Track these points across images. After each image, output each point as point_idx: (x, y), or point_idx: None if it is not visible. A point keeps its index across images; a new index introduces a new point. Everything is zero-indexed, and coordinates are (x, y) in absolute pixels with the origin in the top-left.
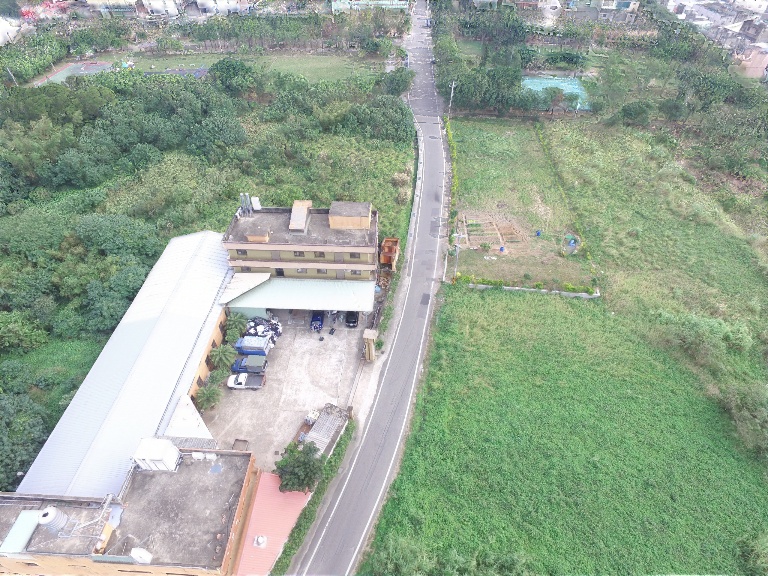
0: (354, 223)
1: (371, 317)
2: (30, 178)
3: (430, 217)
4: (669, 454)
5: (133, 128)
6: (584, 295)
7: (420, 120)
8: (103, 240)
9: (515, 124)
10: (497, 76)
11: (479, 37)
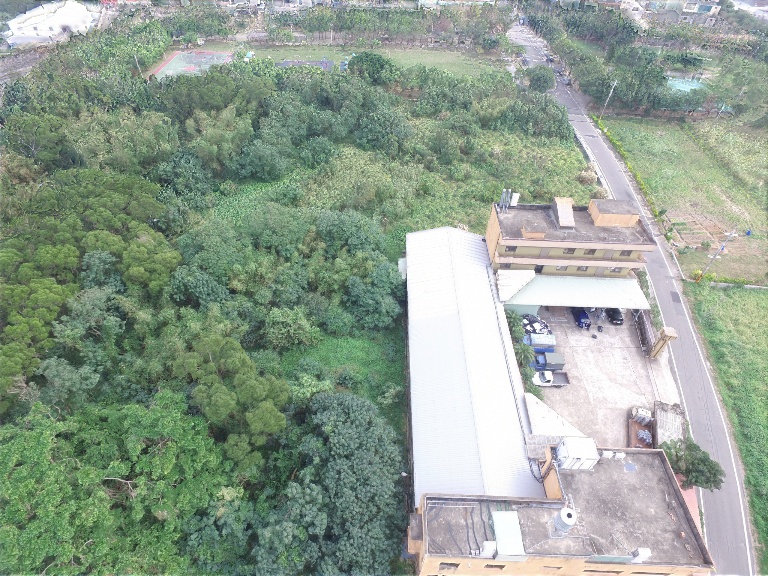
0: (622, 221)
1: (630, 315)
2: (215, 170)
3: None
4: None
5: (302, 120)
6: None
7: (569, 118)
8: (347, 235)
9: (660, 124)
10: (645, 76)
11: (578, 36)
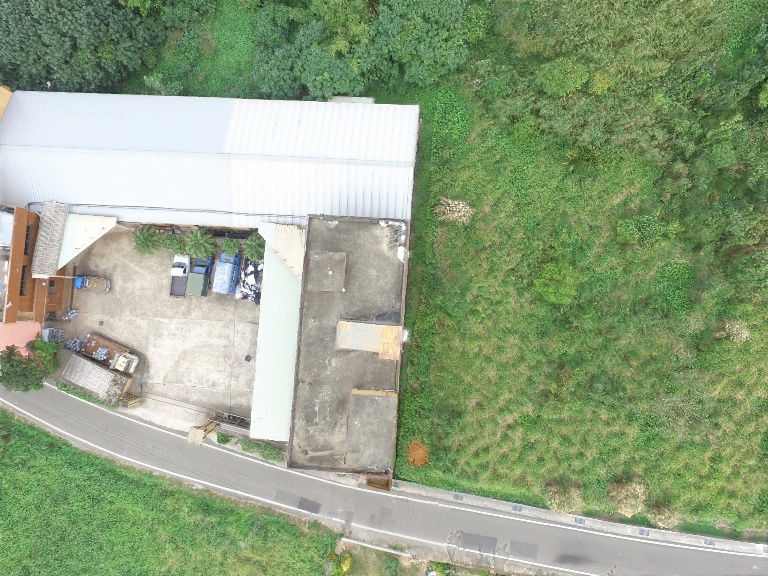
0: None
1: None
2: None
3: (508, 538)
4: None
5: None
6: None
7: None
8: None
9: None
10: None
11: None
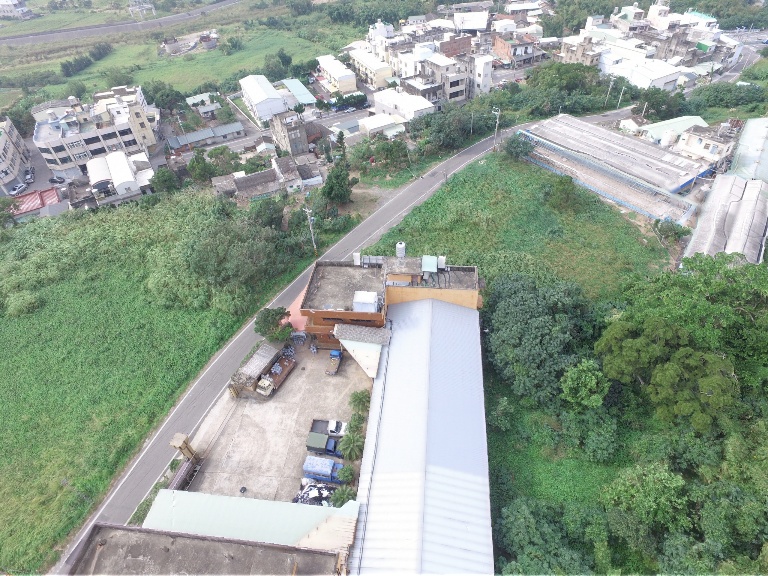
0: None
1: None
2: None
3: None
4: (8, 360)
5: None
6: None
7: None
8: None
9: None
10: None
11: None
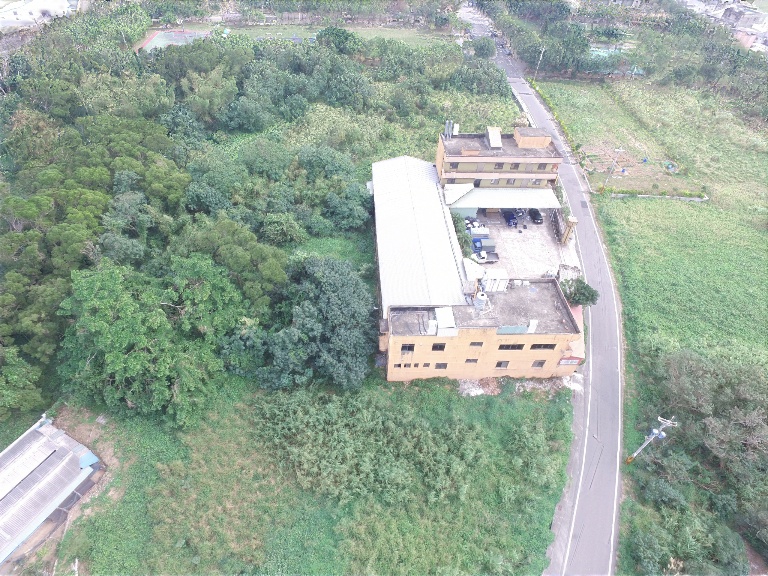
0: (538, 143)
1: (548, 217)
2: (208, 122)
3: None
4: None
5: (279, 82)
6: (697, 199)
7: (508, 81)
8: (324, 163)
9: (585, 85)
10: (570, 44)
11: (520, 16)
